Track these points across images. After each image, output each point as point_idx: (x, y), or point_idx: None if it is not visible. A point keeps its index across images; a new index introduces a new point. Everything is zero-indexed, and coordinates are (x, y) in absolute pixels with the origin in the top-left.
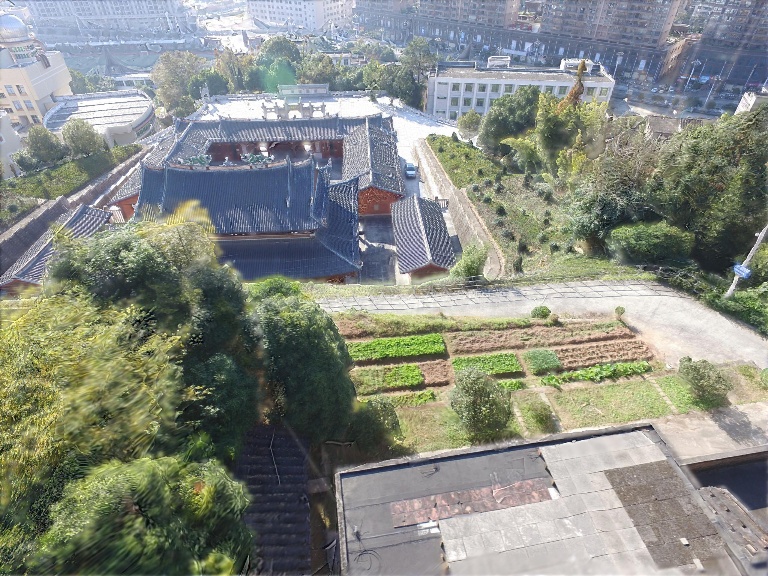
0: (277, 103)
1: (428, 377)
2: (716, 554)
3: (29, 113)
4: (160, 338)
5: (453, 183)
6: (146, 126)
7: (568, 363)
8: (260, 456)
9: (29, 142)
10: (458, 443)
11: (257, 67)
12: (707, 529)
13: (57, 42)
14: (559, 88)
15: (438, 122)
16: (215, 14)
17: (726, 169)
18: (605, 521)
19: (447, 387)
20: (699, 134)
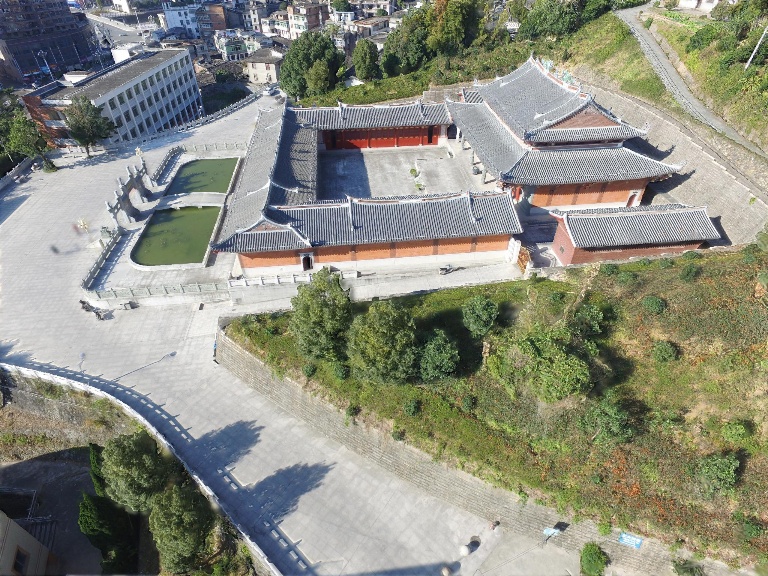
0: None
1: None
2: None
3: None
4: None
5: None
6: None
7: None
8: None
9: (413, 330)
10: None
11: None
12: None
13: None
14: None
15: (182, 132)
16: None
17: None
18: None
19: None
20: None
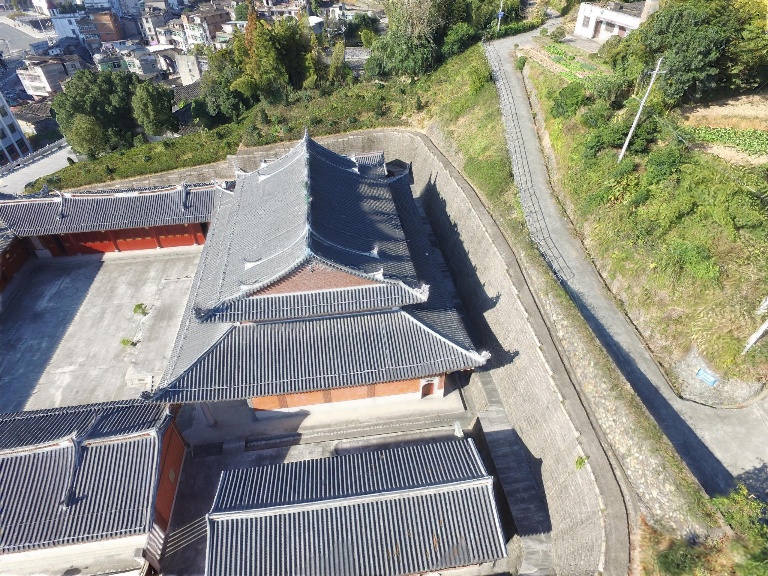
0: None
1: None
2: None
3: None
4: None
5: (211, 161)
6: None
7: None
8: None
9: None
10: None
11: None
12: None
13: None
14: None
15: None
16: None
17: None
18: None
19: None
20: None
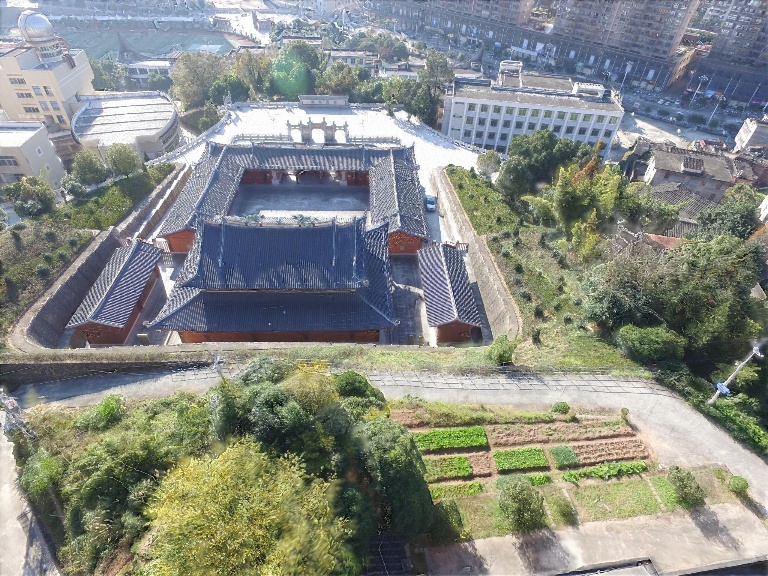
0: (298, 113)
1: (475, 468)
2: None
3: (55, 113)
4: (319, 488)
5: (473, 226)
6: (171, 133)
7: (583, 459)
8: (373, 556)
9: (76, 167)
10: (502, 532)
11: (278, 74)
12: None
13: (62, 14)
14: (571, 114)
15: (454, 144)
16: None
17: (718, 291)
18: None
19: (490, 478)
20: (699, 253)
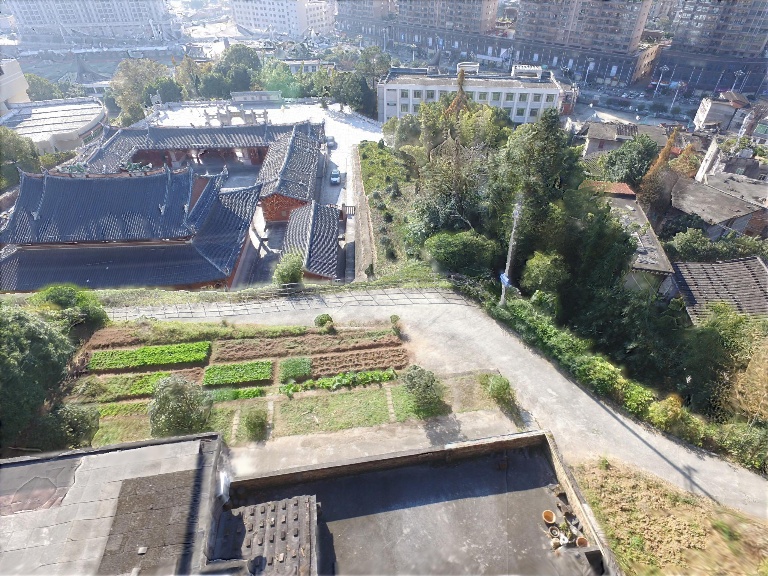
0: None
1: None
2: (161, 563)
3: None
4: None
5: (364, 190)
6: (95, 133)
7: (319, 371)
8: None
9: None
10: None
11: (211, 74)
12: (176, 538)
13: (40, 49)
14: (506, 94)
15: None
16: (201, 21)
17: (520, 178)
18: (83, 530)
19: None
20: None
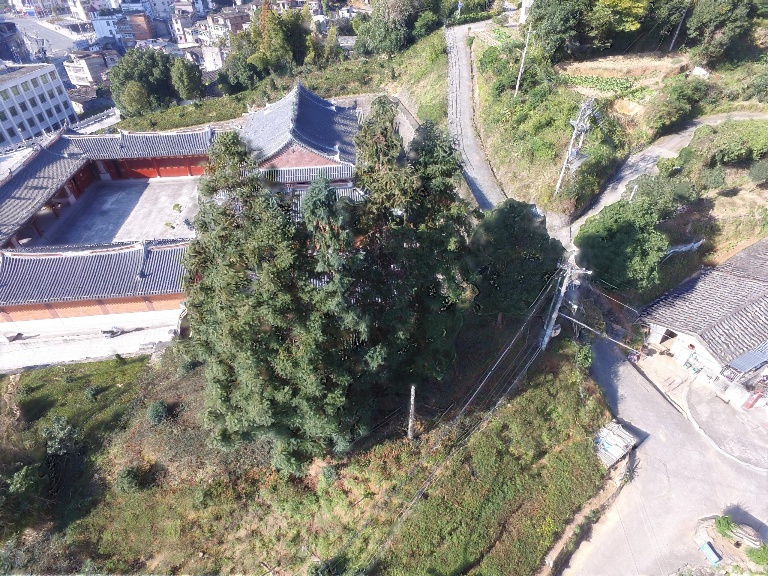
0: None
1: None
2: None
3: None
4: None
5: (230, 118)
6: None
7: None
8: None
9: None
10: None
11: None
12: None
13: None
14: (21, 86)
15: None
16: None
17: None
18: None
19: None
20: None
